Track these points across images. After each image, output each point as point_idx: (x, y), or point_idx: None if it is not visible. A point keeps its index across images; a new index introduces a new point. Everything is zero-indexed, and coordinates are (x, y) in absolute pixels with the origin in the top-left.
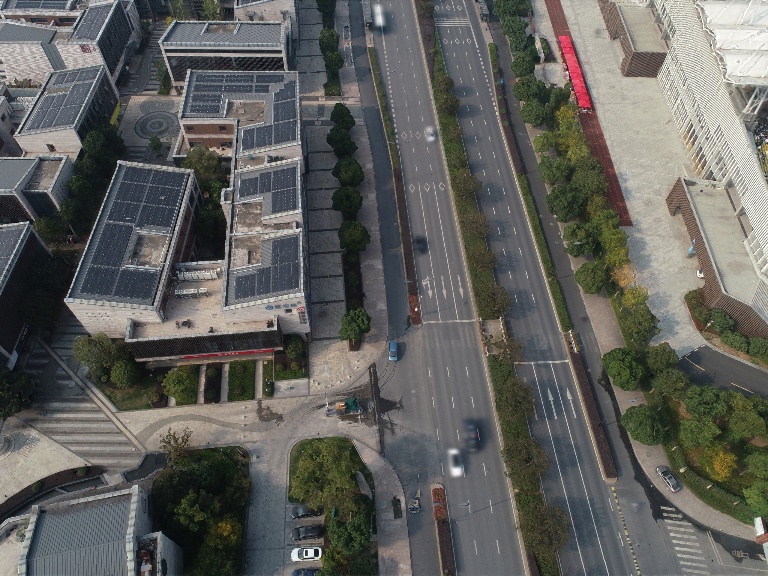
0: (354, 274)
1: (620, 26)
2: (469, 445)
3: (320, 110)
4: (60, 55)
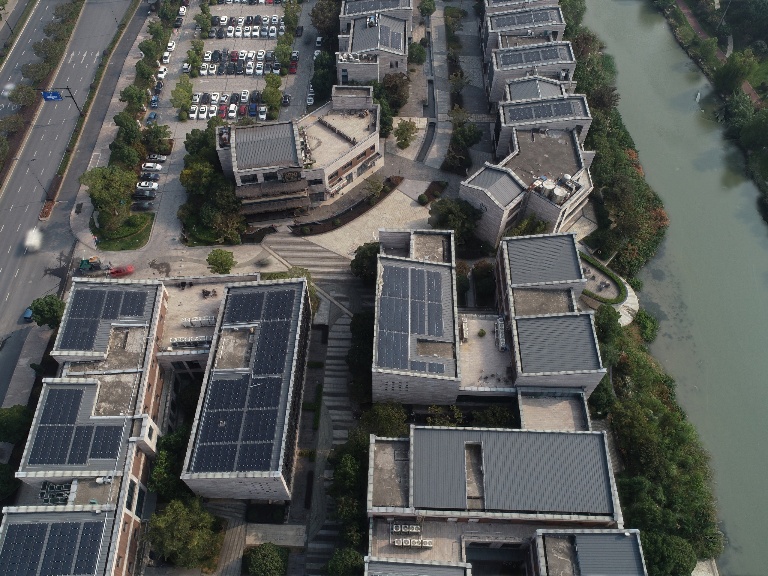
0: (35, 390)
1: None
2: (5, 243)
3: None
4: None
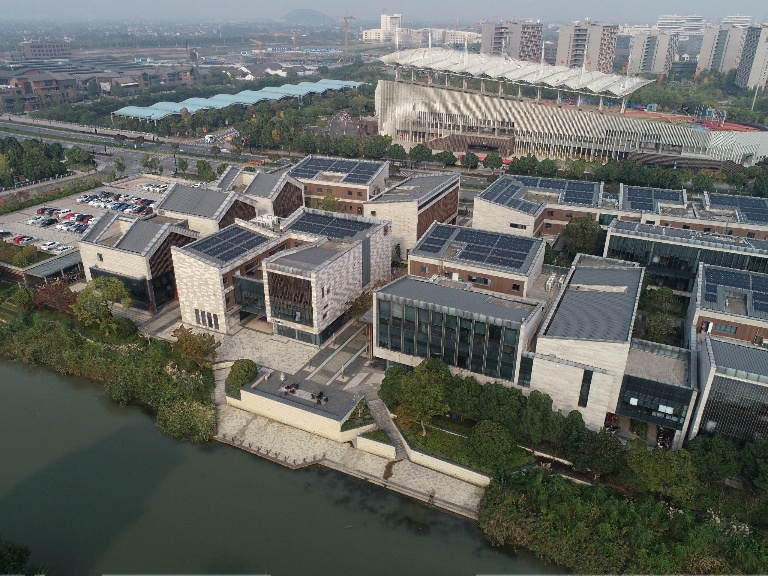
0: None
1: (475, 139)
2: None
3: None
4: (370, 250)
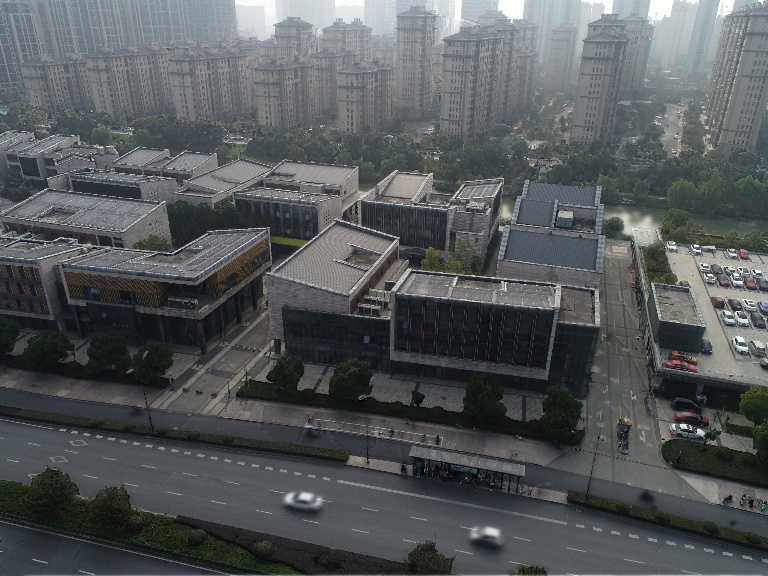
0: None
1: None
2: None
3: (222, 372)
4: None
